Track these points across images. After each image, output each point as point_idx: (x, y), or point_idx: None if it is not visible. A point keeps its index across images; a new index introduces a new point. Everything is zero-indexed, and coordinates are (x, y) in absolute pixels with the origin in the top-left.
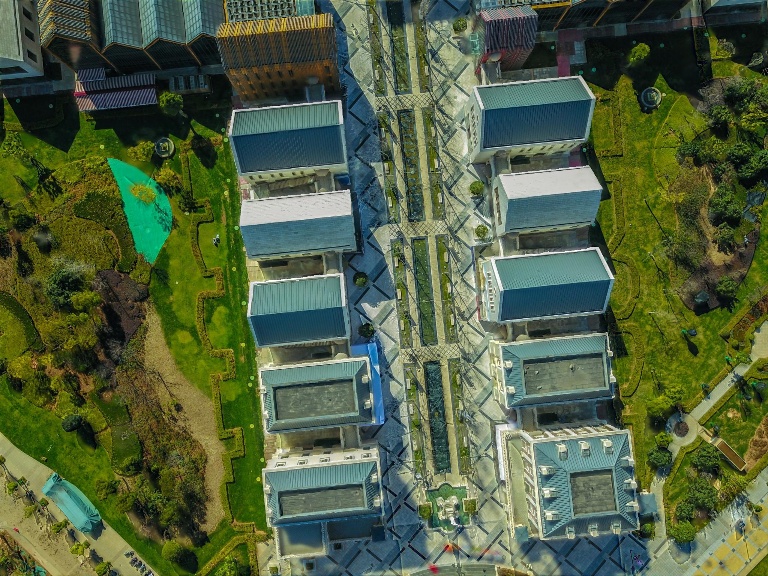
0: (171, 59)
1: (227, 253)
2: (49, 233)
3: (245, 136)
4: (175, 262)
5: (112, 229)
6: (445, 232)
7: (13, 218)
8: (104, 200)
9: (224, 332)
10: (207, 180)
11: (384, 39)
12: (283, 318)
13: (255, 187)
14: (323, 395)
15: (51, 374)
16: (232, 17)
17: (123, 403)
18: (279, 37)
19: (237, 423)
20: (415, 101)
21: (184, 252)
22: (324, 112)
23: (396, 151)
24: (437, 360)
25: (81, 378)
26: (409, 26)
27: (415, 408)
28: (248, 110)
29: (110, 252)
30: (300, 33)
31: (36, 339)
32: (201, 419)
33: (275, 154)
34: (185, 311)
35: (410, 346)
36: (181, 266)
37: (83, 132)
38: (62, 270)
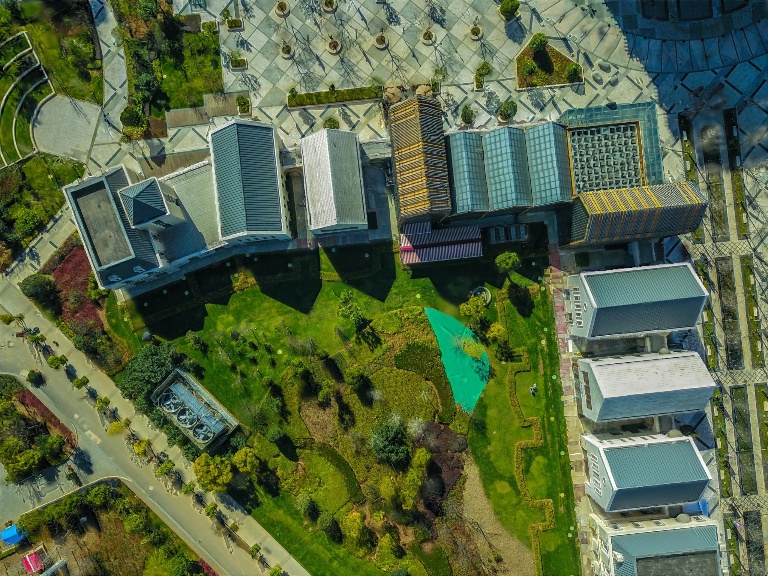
0: (498, 213)
1: (545, 402)
2: (374, 387)
3: (609, 307)
4: (492, 412)
5: (432, 380)
6: (764, 381)
7: (352, 379)
8: (424, 351)
9: (543, 482)
10: (523, 329)
11: (701, 186)
12: (646, 489)
13: (573, 336)
14: (684, 565)
15: (370, 525)
16: (578, 179)
17: (444, 555)
18: (653, 212)
19: (557, 574)
20: (733, 248)
21: (501, 401)
22: (679, 278)
23: (714, 299)
24: (757, 510)
25: (400, 529)
26: (726, 173)
27: (735, 558)
28: (596, 273)
29: (431, 404)
30: (675, 208)
31: (357, 491)
32: (521, 570)
33: (630, 321)
34: (503, 461)
35: (730, 496)
36: (498, 416)
37: (399, 281)
38: (390, 425)
